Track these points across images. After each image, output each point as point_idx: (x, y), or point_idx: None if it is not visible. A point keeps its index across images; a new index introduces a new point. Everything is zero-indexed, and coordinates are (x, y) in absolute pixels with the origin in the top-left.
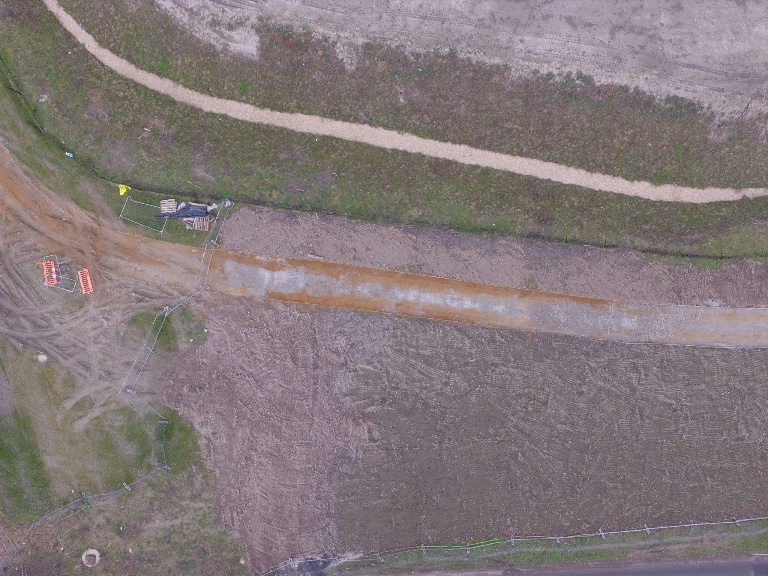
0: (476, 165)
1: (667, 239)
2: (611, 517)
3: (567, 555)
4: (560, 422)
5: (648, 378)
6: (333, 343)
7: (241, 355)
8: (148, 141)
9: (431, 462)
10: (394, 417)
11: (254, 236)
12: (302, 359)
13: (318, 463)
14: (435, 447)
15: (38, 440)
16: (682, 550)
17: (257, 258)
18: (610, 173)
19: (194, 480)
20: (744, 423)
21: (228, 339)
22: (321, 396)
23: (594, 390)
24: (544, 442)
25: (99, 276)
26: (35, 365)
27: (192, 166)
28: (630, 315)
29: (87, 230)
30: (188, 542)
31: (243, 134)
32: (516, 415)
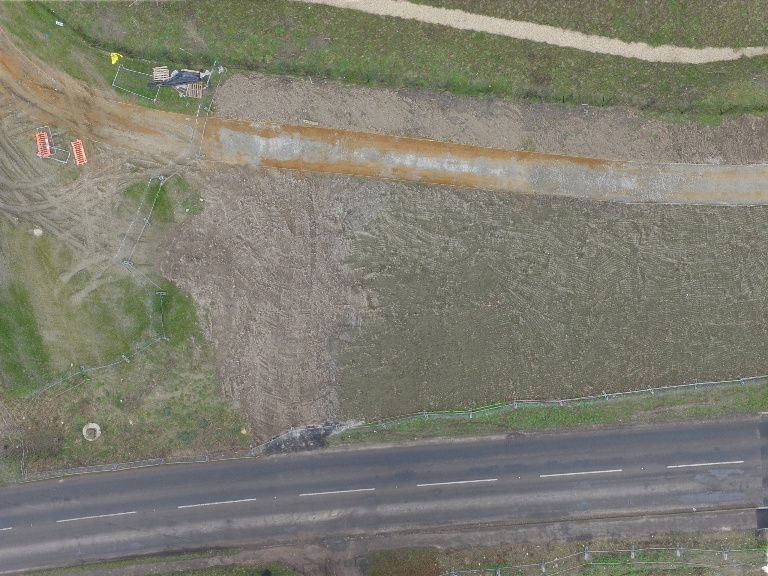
0: (471, 30)
1: (666, 97)
2: (614, 378)
3: (571, 418)
4: (561, 284)
5: (649, 238)
6: (330, 210)
7: (238, 224)
8: (139, 8)
9: (431, 328)
10: (393, 284)
11: (248, 103)
12: (299, 227)
13: (318, 331)
14: (435, 313)
15: (36, 314)
16: (687, 410)
17: (252, 125)
18: (607, 35)
19: (193, 352)
20: (747, 281)
21: (224, 208)
22: (319, 264)
23: (595, 251)
24: (545, 305)
25: (93, 146)
26: (31, 239)
27: (184, 33)
28: (630, 175)
29: (79, 100)
30: (189, 413)
31: (235, 3)
32: (516, 279)
